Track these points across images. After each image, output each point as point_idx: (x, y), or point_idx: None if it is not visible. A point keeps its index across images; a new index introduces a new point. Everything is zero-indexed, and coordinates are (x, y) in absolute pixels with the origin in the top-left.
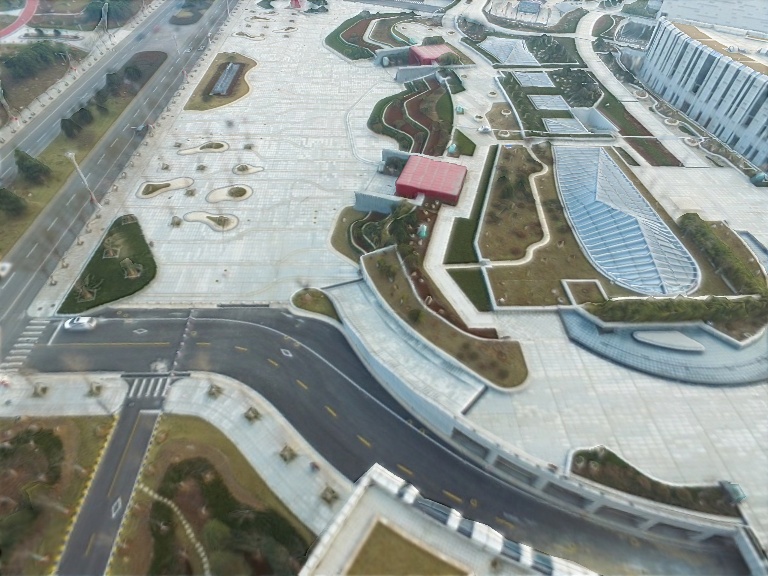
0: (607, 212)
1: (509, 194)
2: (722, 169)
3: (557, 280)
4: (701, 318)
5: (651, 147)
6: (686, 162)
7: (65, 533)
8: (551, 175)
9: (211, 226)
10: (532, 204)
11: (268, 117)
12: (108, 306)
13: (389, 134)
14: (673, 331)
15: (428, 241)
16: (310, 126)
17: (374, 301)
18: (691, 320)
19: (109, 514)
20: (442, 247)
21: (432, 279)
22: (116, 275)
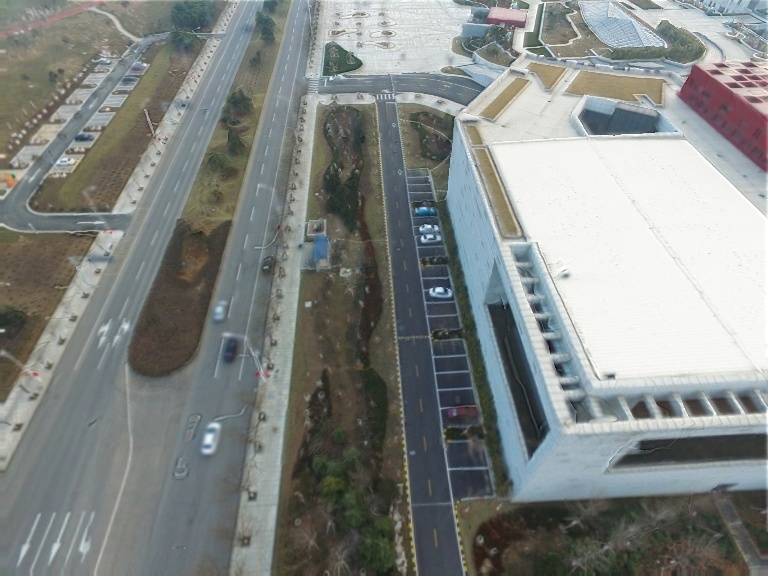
0: (614, 21)
1: (556, 19)
2: (688, 9)
3: (587, 49)
4: (664, 55)
5: (643, 1)
6: (665, 7)
7: (377, 130)
8: (579, 14)
9: (380, 47)
10: (569, 25)
11: (386, 0)
12: (345, 74)
13: (470, 4)
14: (649, 62)
15: (512, 40)
16: (416, 4)
17: (487, 67)
18: (659, 57)
19: (392, 126)
20: (521, 42)
21: (519, 52)
22: (343, 62)
